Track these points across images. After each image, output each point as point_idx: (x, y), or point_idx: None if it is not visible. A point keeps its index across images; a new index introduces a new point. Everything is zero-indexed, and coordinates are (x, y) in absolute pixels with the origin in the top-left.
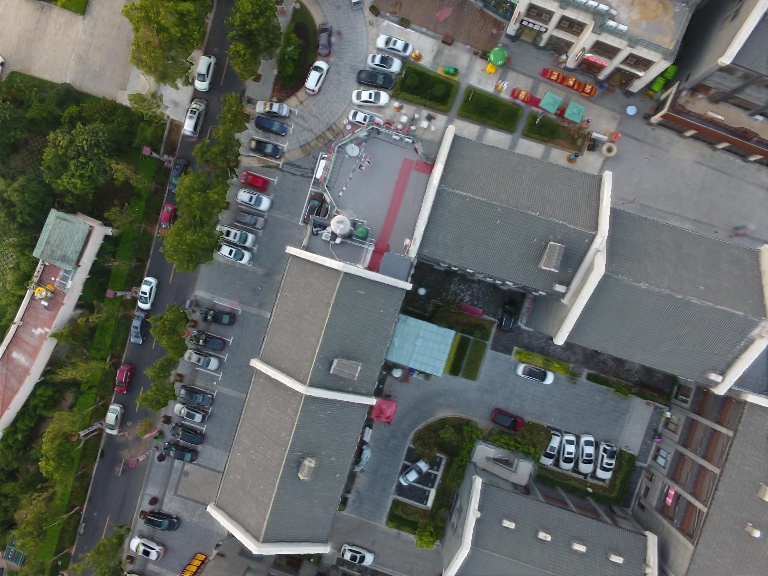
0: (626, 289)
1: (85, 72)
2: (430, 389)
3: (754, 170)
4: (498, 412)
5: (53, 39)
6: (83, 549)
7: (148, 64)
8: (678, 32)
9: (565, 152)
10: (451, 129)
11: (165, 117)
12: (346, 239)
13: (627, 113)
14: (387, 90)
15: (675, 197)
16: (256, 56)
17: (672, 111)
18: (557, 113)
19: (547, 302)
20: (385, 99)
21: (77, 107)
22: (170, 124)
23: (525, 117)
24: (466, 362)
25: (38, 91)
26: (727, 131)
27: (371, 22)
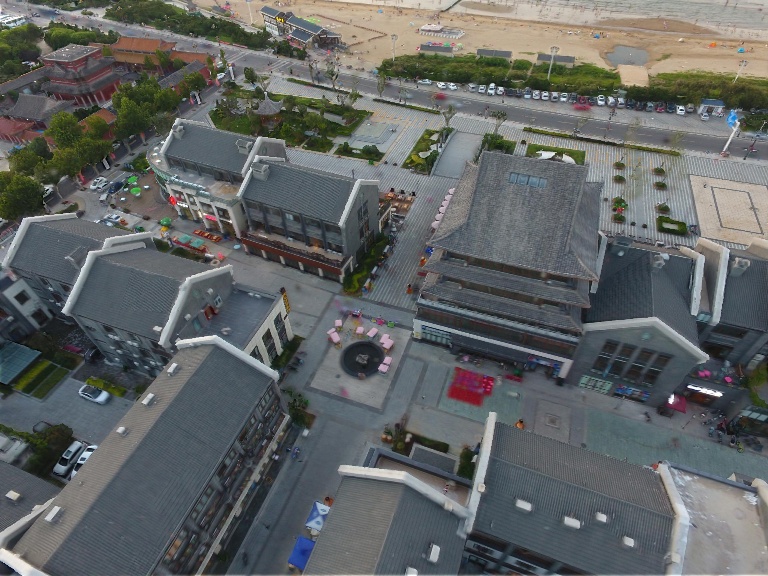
0: (109, 268)
1: None
2: (1, 407)
3: (308, 277)
4: (41, 421)
5: None
6: None
7: None
8: None
9: None
10: None
11: None
12: None
13: (234, 248)
14: None
15: None
16: (19, 209)
17: (242, 236)
18: (192, 247)
19: None
20: None
21: None
22: None
23: (173, 249)
24: (43, 383)
25: None
26: (272, 245)
27: (109, 211)
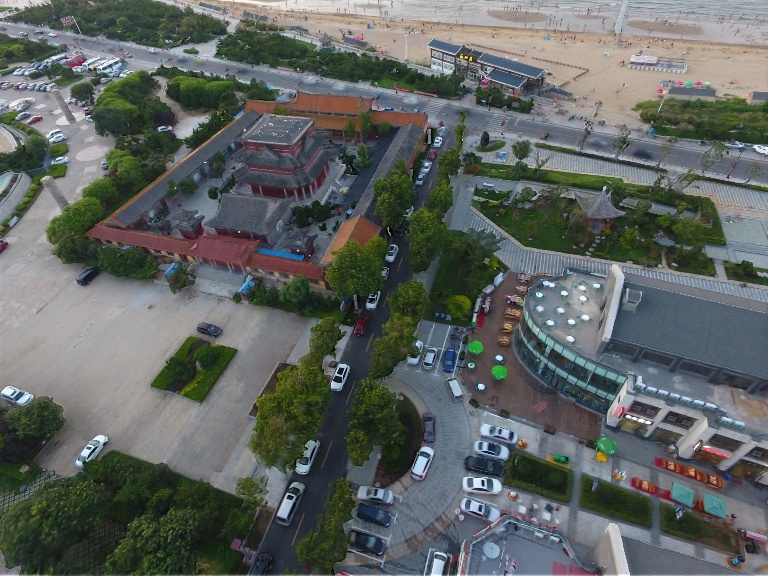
0: None
1: (185, 453)
2: None
3: None
4: None
5: (164, 422)
6: None
7: (267, 448)
8: None
9: (721, 554)
10: (615, 528)
11: (263, 503)
12: None
13: None
14: (498, 477)
15: None
16: (369, 442)
17: None
18: None
19: None
20: (498, 487)
21: (169, 490)
22: (260, 510)
23: (657, 510)
24: None
25: (132, 471)
26: None
27: (471, 413)
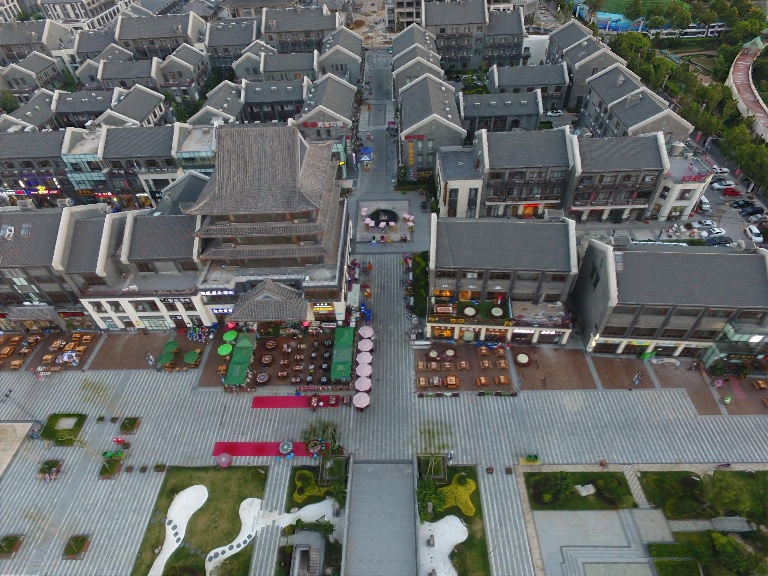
0: None
1: None
2: None
3: None
4: None
5: None
6: (662, 95)
7: None
8: (583, 248)
9: None
10: (668, 165)
11: None
12: None
13: None
14: None
15: None
16: None
17: None
18: None
19: None
20: (704, 234)
21: None
22: None
23: None
24: None
25: None
26: None
27: None
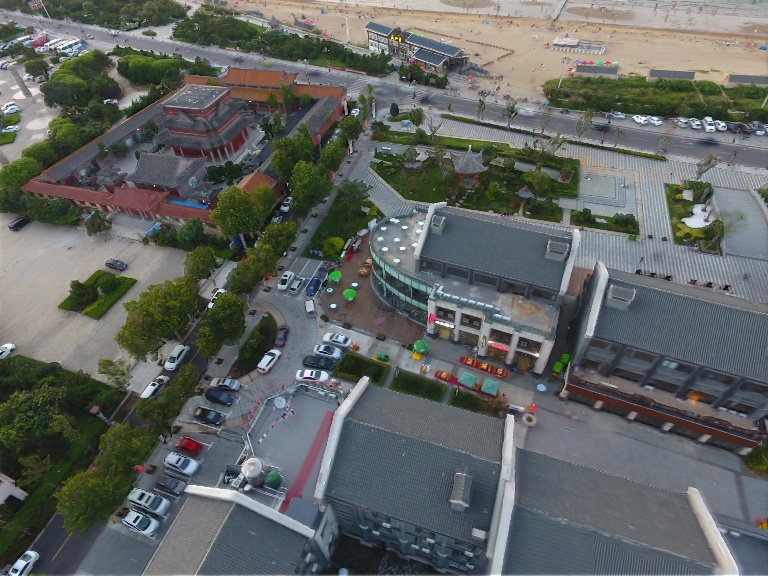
0: (545, 526)
1: (77, 356)
2: None
3: (675, 441)
4: None
5: (65, 334)
6: None
7: (127, 339)
8: (552, 322)
9: None
10: (365, 378)
11: (126, 385)
12: (257, 488)
13: (538, 390)
14: (327, 371)
15: (607, 466)
16: (220, 340)
17: (571, 382)
18: (476, 390)
19: (482, 574)
20: (325, 377)
21: (53, 377)
22: (130, 395)
23: (448, 393)
24: None
25: (28, 367)
26: (626, 399)
27: (321, 326)
